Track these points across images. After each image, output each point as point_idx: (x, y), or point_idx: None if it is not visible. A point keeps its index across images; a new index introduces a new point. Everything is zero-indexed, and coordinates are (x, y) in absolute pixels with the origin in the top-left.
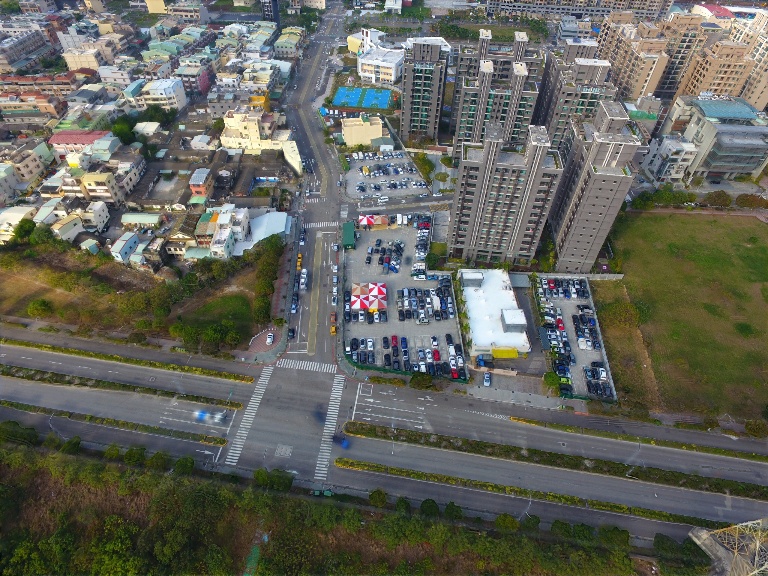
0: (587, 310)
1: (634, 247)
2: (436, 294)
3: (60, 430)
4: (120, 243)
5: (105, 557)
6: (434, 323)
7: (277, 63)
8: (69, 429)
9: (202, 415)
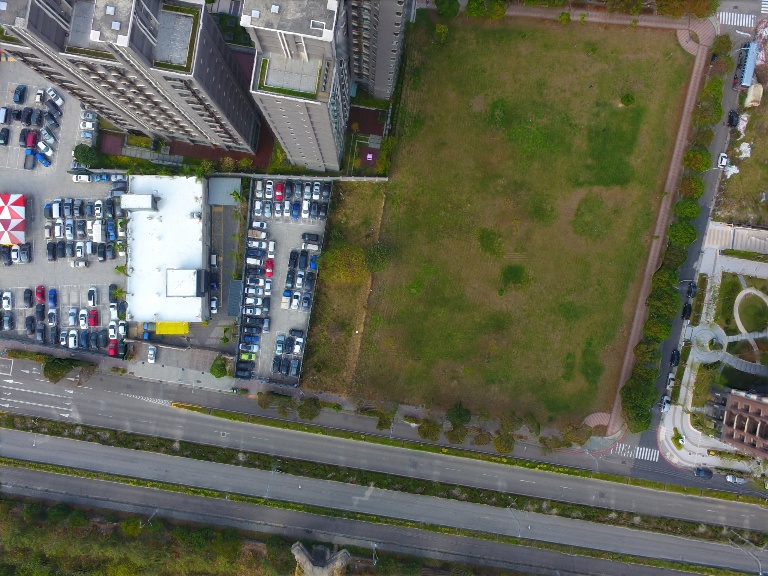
0: (310, 246)
1: (436, 108)
2: (105, 210)
3: None
4: None
5: None
6: (97, 264)
7: None
8: None
9: None
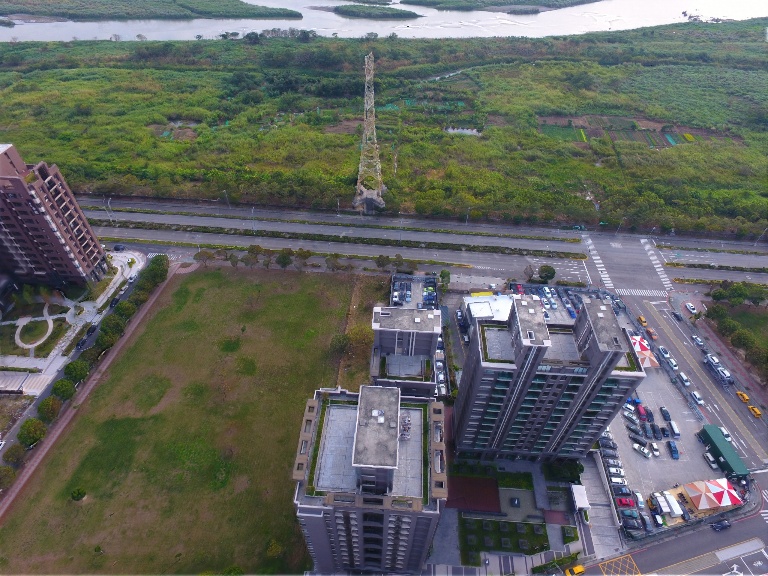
0: None
1: (285, 474)
2: None
3: (766, 249)
4: None
5: (668, 207)
6: None
7: None
8: (761, 249)
9: (687, 259)
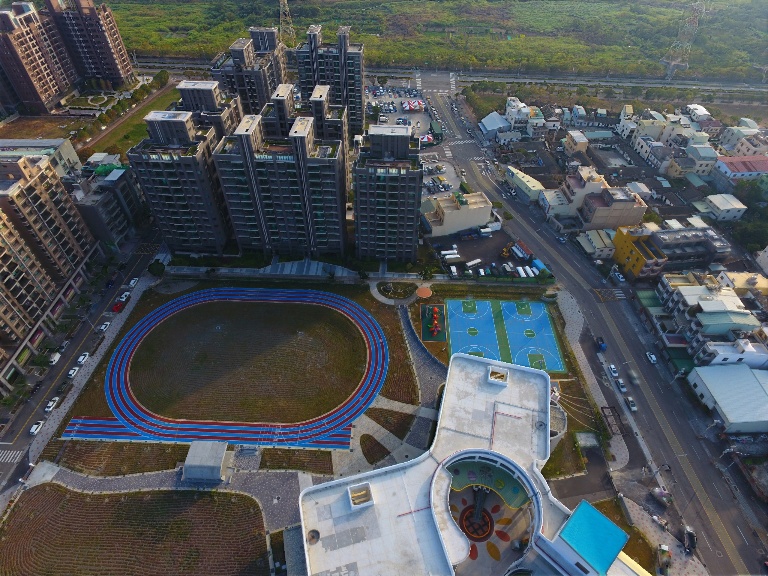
0: None
1: None
2: None
3: None
4: (580, 107)
5: None
6: None
7: (754, 401)
8: None
9: None
